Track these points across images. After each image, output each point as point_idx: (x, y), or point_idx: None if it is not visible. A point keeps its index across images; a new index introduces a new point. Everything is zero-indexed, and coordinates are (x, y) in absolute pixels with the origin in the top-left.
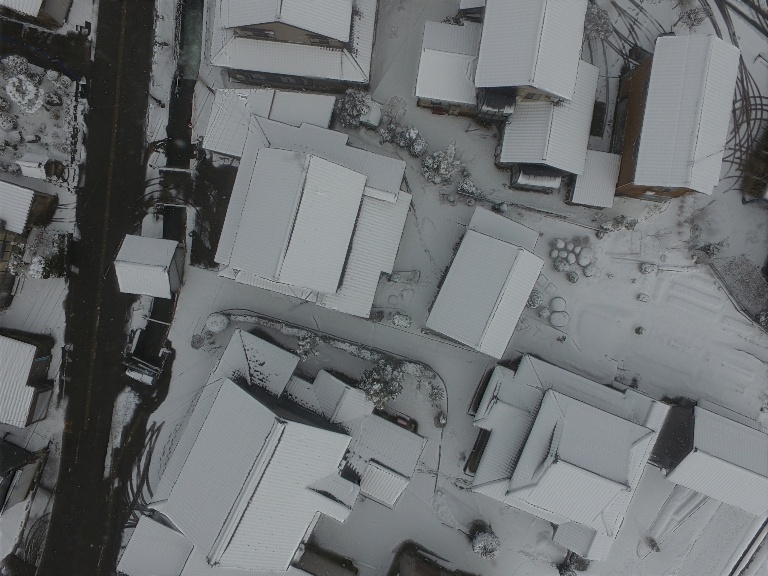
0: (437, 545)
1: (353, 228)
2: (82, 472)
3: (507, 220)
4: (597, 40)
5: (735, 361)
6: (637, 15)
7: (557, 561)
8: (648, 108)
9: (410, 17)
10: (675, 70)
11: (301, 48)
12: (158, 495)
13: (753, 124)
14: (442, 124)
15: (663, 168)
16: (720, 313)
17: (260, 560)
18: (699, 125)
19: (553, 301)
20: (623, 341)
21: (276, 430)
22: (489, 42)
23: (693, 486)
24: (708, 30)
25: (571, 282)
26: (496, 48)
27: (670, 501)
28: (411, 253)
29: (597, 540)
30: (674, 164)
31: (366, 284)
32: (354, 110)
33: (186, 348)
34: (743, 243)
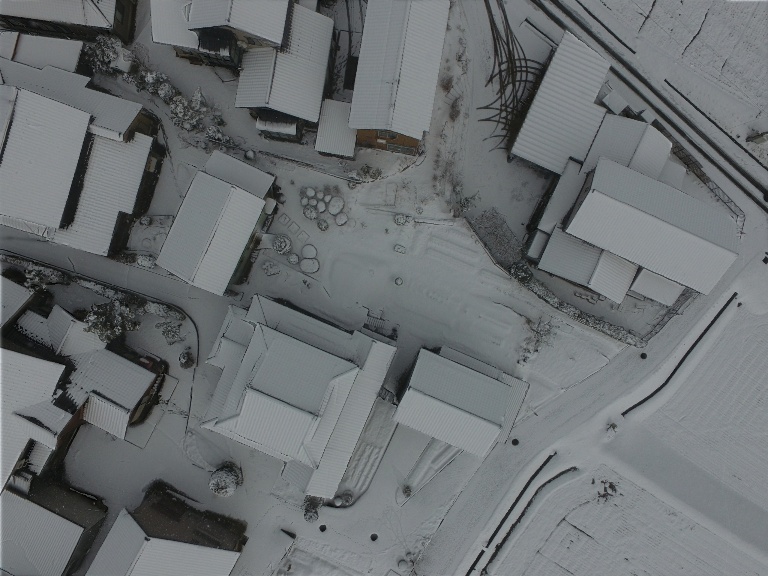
0: (187, 485)
1: (78, 164)
2: None
3: (243, 164)
4: None
5: (493, 314)
6: None
7: None
8: (361, 54)
9: None
10: (382, 18)
11: None
12: None
13: (518, 85)
14: (200, 74)
15: (370, 111)
16: (478, 266)
17: None
18: (400, 70)
19: (303, 248)
20: (380, 291)
21: None
22: None
23: (417, 426)
24: None
25: (321, 230)
26: None
27: (428, 450)
28: (166, 198)
29: (318, 476)
30: (379, 107)
31: (102, 222)
32: (105, 56)
33: None
34: (509, 201)
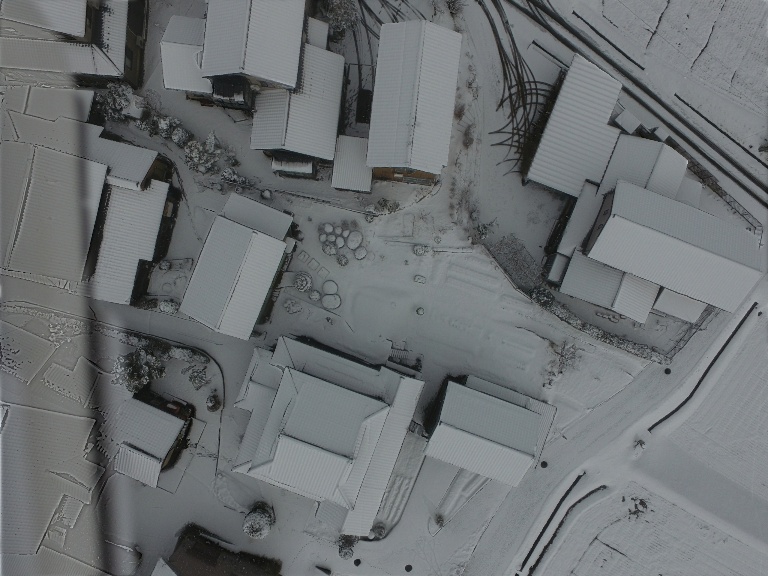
0: (219, 528)
1: (97, 216)
2: None
3: (261, 206)
4: (362, 31)
5: (516, 338)
6: (400, 6)
7: None
8: (375, 92)
9: (179, 13)
10: (395, 55)
11: (52, 45)
12: None
13: (529, 108)
14: (211, 115)
15: (388, 149)
16: (499, 292)
17: None
18: (416, 107)
19: (324, 284)
20: (402, 322)
21: None
22: (210, 33)
23: (449, 460)
24: (481, 19)
25: (341, 265)
26: (215, 38)
27: (458, 478)
28: (184, 241)
29: (353, 515)
30: (396, 145)
31: (123, 271)
32: (116, 104)
33: None
34: (525, 224)
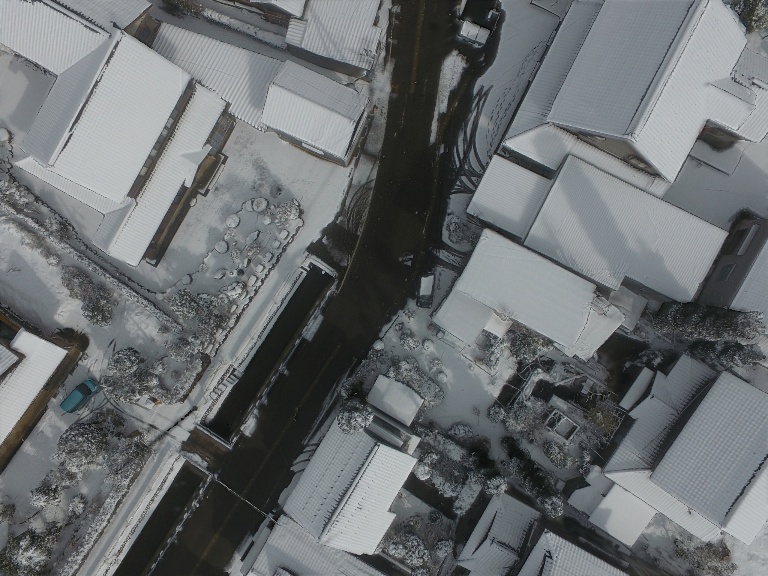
0: None
1: None
2: (408, 137)
3: None
4: None
5: None
6: None
7: None
8: None
9: None
10: None
11: None
12: (516, 130)
13: None
14: None
15: None
16: None
17: (661, 156)
18: None
19: None
20: None
21: None
22: None
23: None
24: None
25: None
26: None
27: None
28: None
29: None
30: None
31: None
32: None
33: (516, 10)
34: None
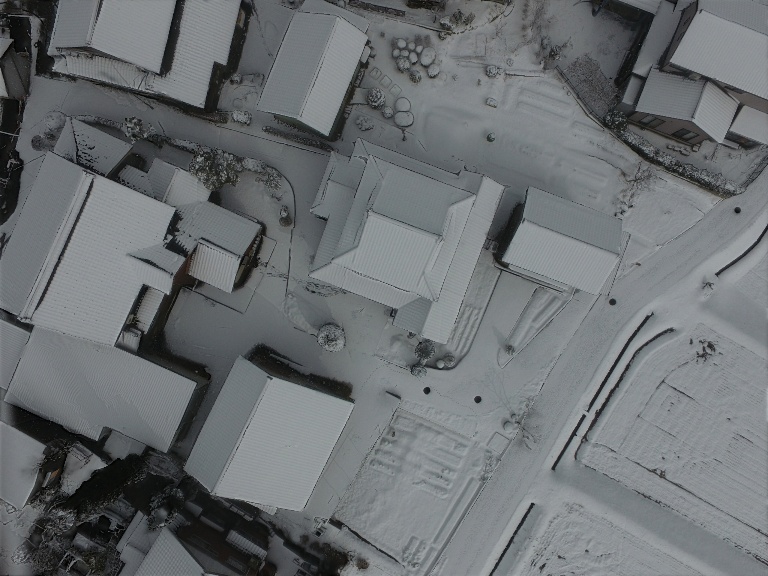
0: (290, 349)
1: (176, 6)
2: None
3: (338, 8)
4: None
5: (587, 167)
6: None
7: (411, 363)
8: None
9: None
10: None
11: None
12: None
13: None
14: None
15: None
16: (570, 119)
17: (81, 327)
18: None
19: (397, 101)
20: (473, 146)
21: (81, 179)
22: None
23: (529, 265)
24: None
25: (414, 82)
26: None
27: (528, 308)
28: (255, 57)
29: (433, 318)
30: None
31: (198, 72)
32: None
33: None
34: (595, 55)
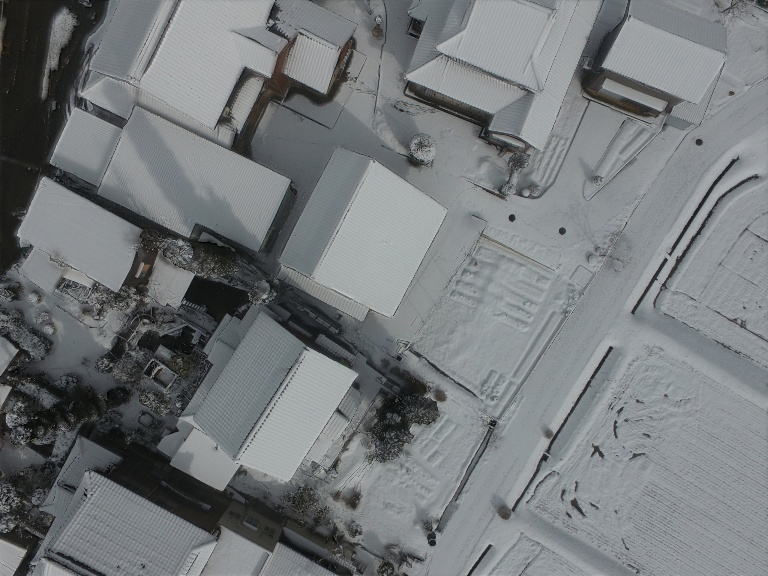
0: None
1: None
2: (20, 95)
3: None
4: None
5: None
6: None
7: (499, 185)
8: None
9: None
10: None
11: None
12: (90, 82)
13: None
14: None
15: None
16: None
17: (185, 101)
18: None
19: None
20: None
21: None
22: None
23: (630, 71)
24: None
25: None
26: None
27: (616, 140)
28: None
29: (532, 120)
30: None
31: None
32: None
33: None
34: None
